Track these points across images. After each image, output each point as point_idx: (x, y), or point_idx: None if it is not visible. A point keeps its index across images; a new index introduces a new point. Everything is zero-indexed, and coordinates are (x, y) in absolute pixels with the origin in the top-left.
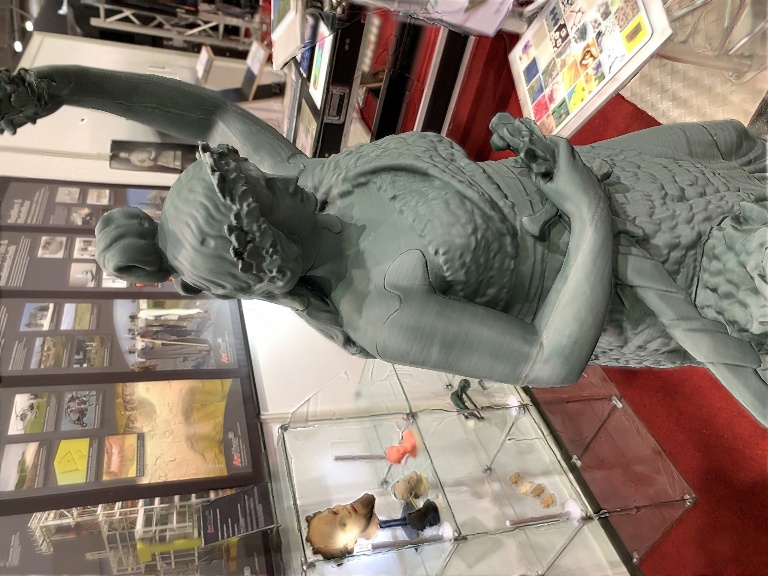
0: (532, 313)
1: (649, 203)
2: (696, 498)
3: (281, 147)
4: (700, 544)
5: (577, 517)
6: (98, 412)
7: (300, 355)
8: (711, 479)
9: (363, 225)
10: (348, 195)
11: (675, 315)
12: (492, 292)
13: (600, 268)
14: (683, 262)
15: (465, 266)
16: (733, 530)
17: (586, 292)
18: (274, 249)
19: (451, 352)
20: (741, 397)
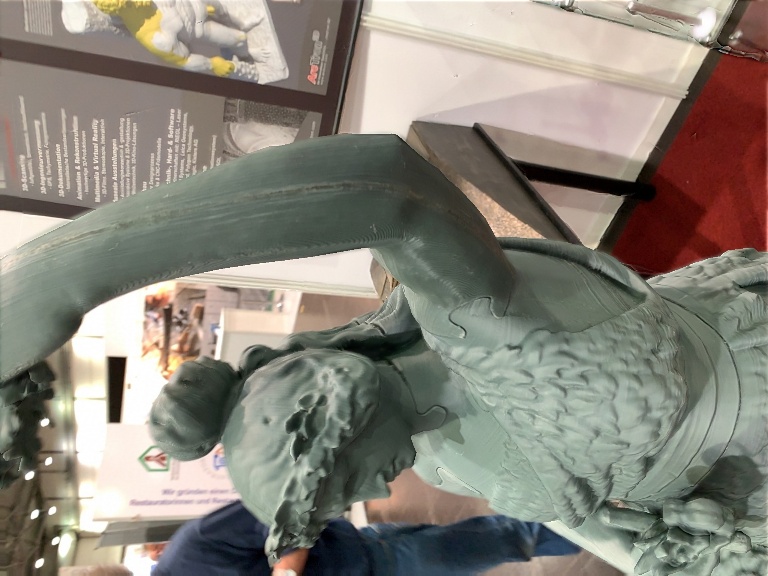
0: None
1: None
2: None
3: (455, 298)
4: None
5: (700, 34)
6: None
7: None
8: None
9: (462, 439)
10: None
11: None
12: None
13: None
14: None
15: None
16: None
17: None
18: None
19: None
20: None
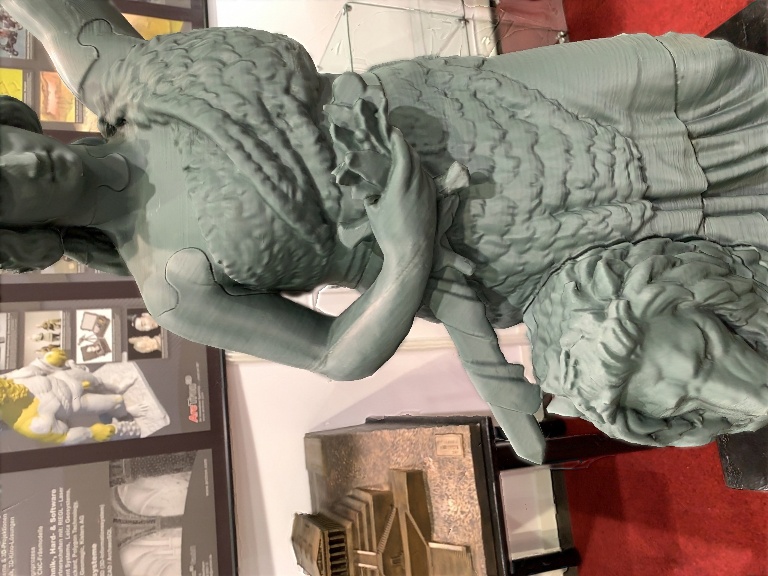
0: (352, 286)
1: (508, 219)
2: None
3: (69, 10)
4: None
5: None
6: (29, 39)
7: (265, 3)
8: None
9: (153, 186)
10: (145, 128)
11: (471, 358)
12: (298, 281)
13: (397, 318)
14: (522, 284)
15: (255, 276)
16: None
17: (376, 335)
18: (6, 261)
19: (231, 348)
20: (505, 431)
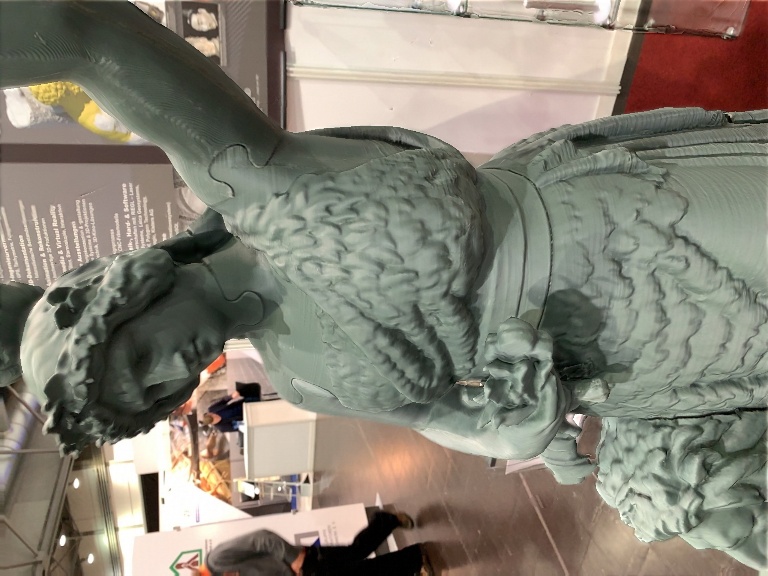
0: None
1: None
2: (736, 38)
3: (199, 144)
4: (700, 69)
5: (600, 19)
6: None
7: None
8: (764, 38)
9: (288, 328)
10: None
11: (548, 455)
12: None
13: None
14: None
15: None
16: (731, 88)
17: None
18: None
19: None
20: None
